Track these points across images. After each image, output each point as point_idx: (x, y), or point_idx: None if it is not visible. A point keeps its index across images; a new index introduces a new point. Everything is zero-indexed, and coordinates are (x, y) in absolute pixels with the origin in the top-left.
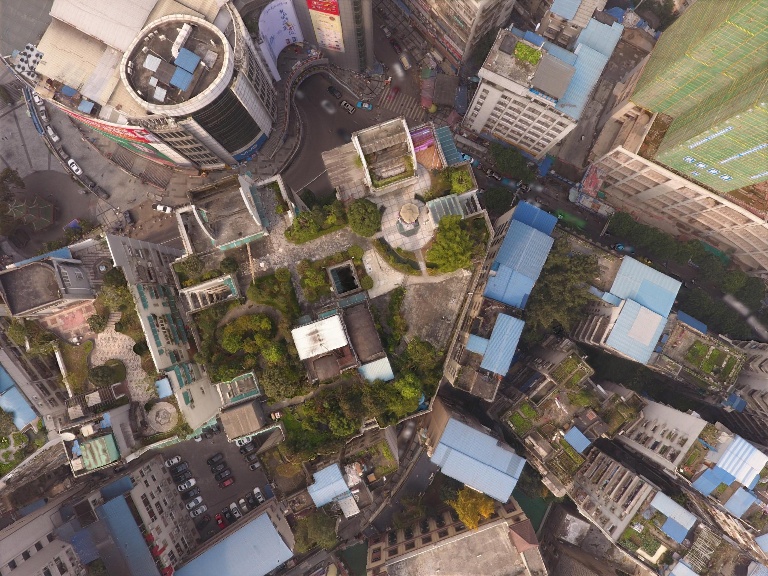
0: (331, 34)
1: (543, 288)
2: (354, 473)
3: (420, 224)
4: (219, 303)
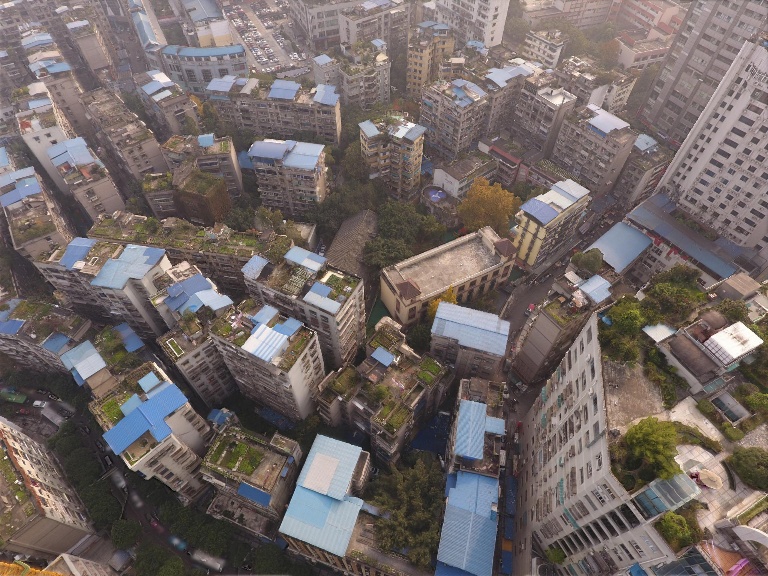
0: None
1: (426, 506)
2: (579, 299)
3: None
4: None
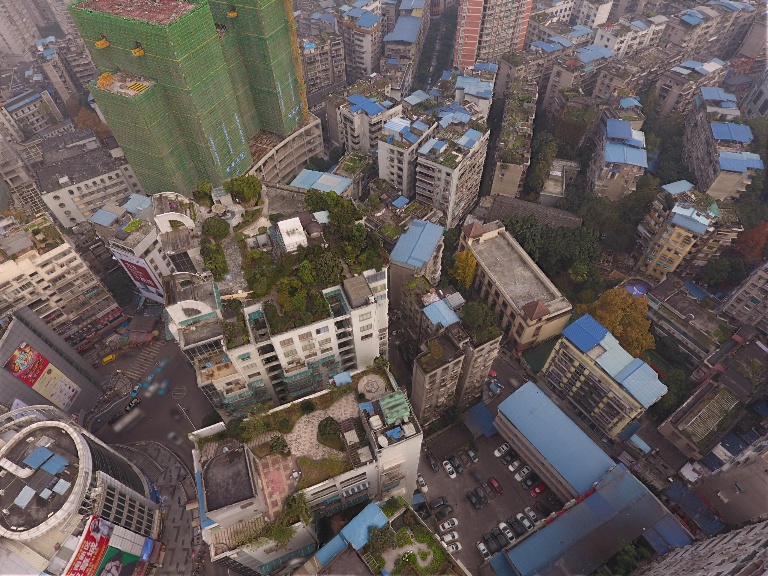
0: (61, 387)
1: None
2: (429, 298)
3: (228, 210)
4: (264, 309)
